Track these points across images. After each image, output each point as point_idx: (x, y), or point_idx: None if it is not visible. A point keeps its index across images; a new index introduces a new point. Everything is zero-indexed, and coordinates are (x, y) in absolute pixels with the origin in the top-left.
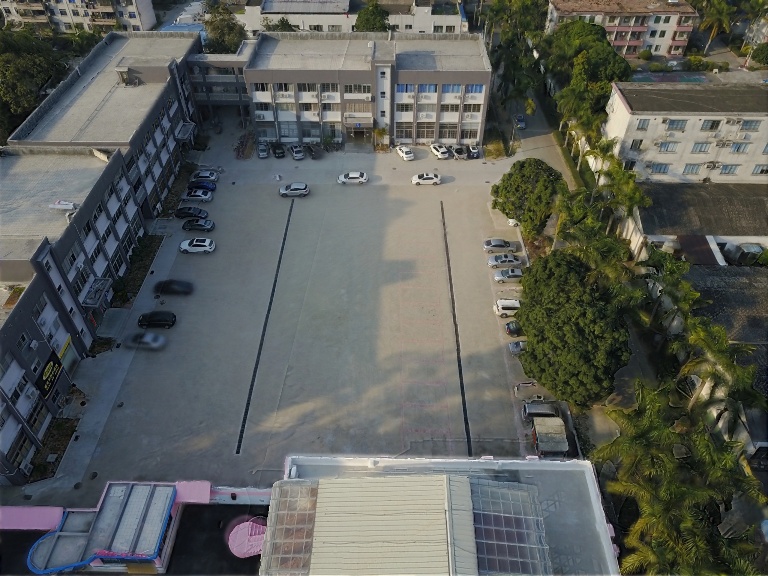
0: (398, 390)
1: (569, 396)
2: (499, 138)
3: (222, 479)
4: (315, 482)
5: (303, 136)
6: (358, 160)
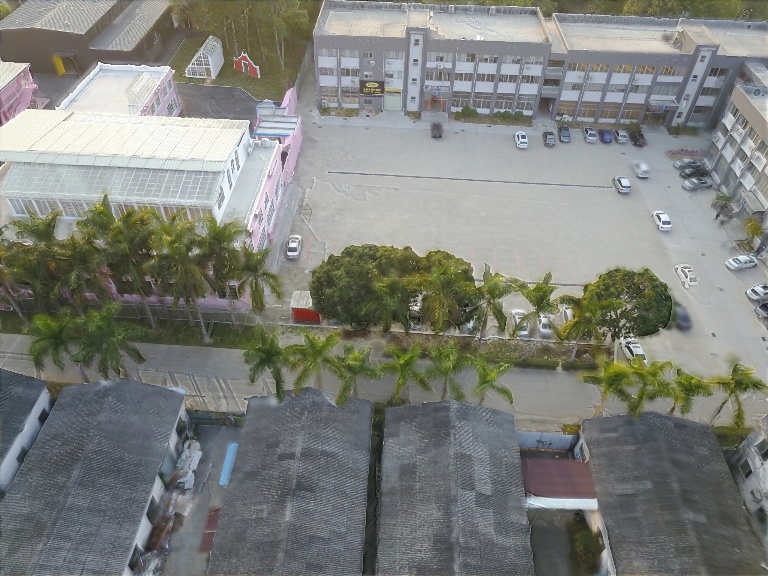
0: (373, 238)
1: None
2: None
3: (311, 167)
4: None
5: (724, 183)
6: (707, 228)
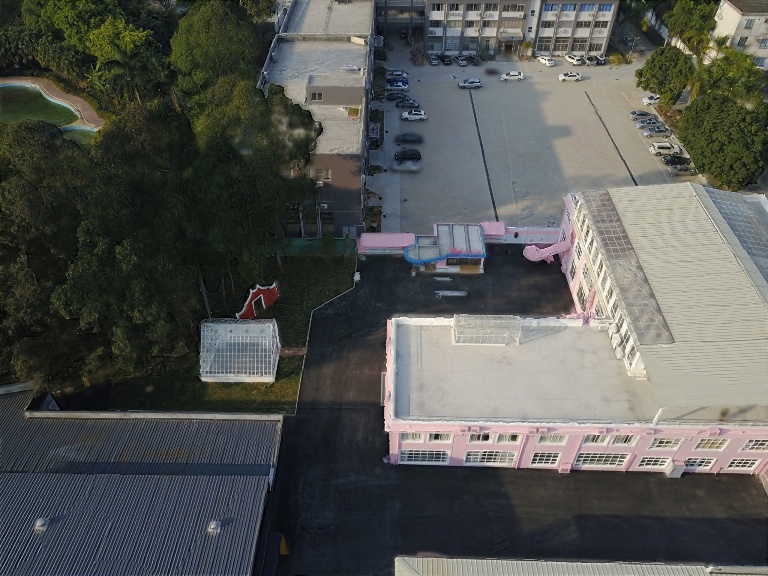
0: None
1: (733, 177)
2: (617, 52)
3: None
4: (604, 191)
5: (463, 50)
6: (510, 66)
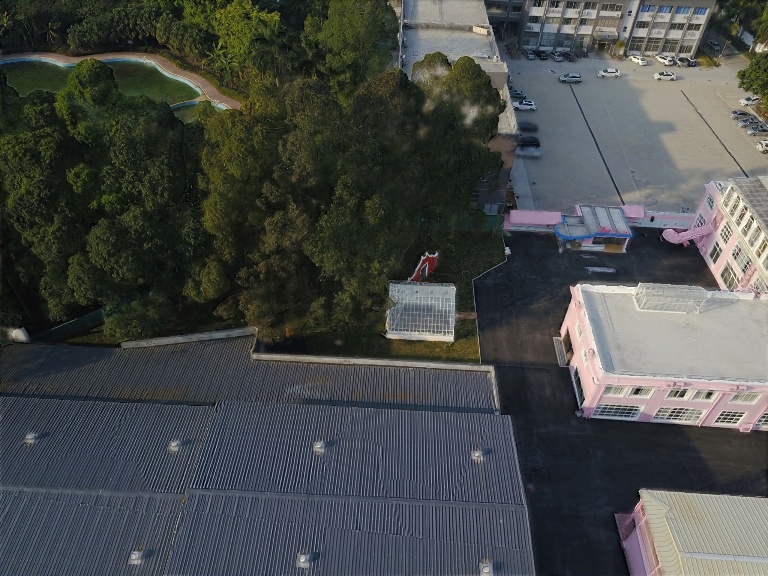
0: None
1: None
2: (705, 54)
3: None
4: (754, 178)
5: (557, 46)
6: (604, 64)
